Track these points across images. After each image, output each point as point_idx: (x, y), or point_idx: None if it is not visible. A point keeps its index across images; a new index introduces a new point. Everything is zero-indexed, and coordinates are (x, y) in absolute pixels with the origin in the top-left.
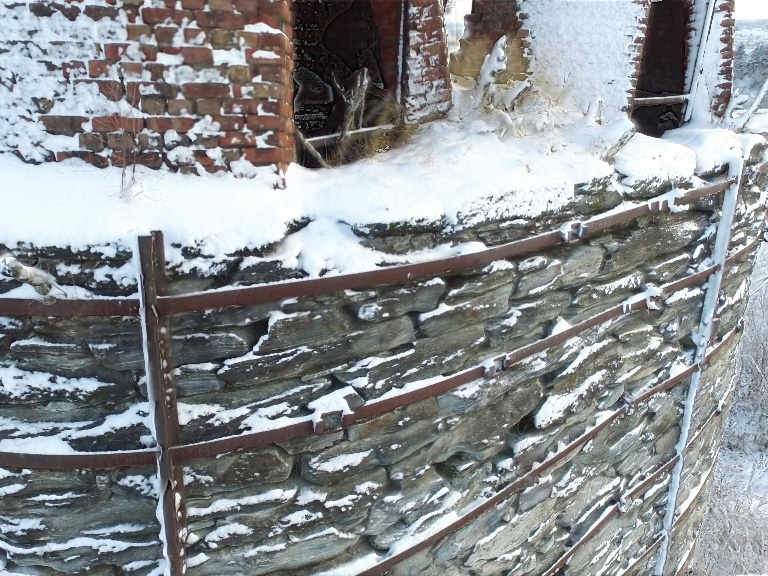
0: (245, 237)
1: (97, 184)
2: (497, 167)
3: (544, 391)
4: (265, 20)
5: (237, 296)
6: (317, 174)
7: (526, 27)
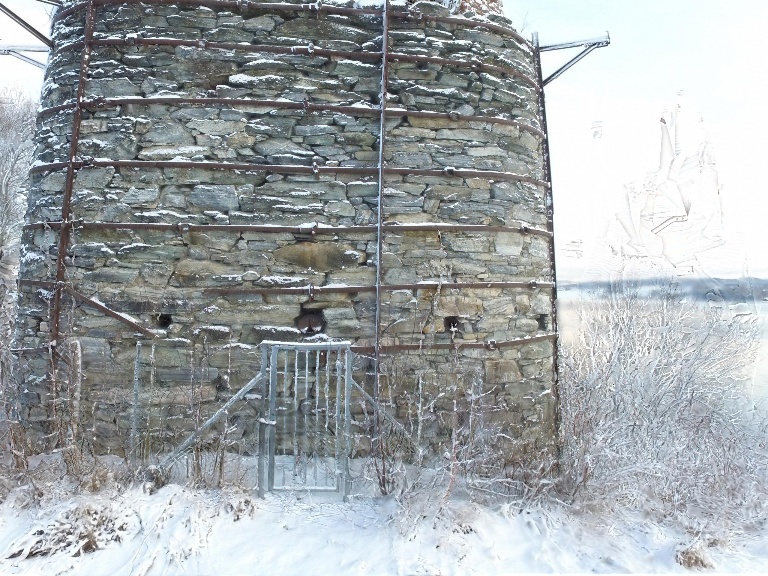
0: None
1: None
2: None
3: (240, 72)
4: None
5: (111, 0)
6: None
7: None
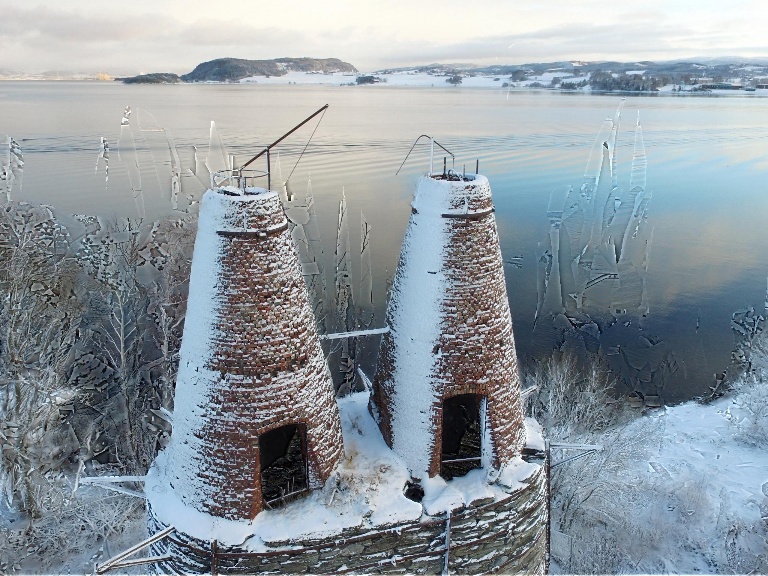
0: (234, 542)
1: (211, 520)
2: (315, 522)
3: None
4: (250, 487)
5: (231, 555)
6: (264, 518)
7: (392, 430)
